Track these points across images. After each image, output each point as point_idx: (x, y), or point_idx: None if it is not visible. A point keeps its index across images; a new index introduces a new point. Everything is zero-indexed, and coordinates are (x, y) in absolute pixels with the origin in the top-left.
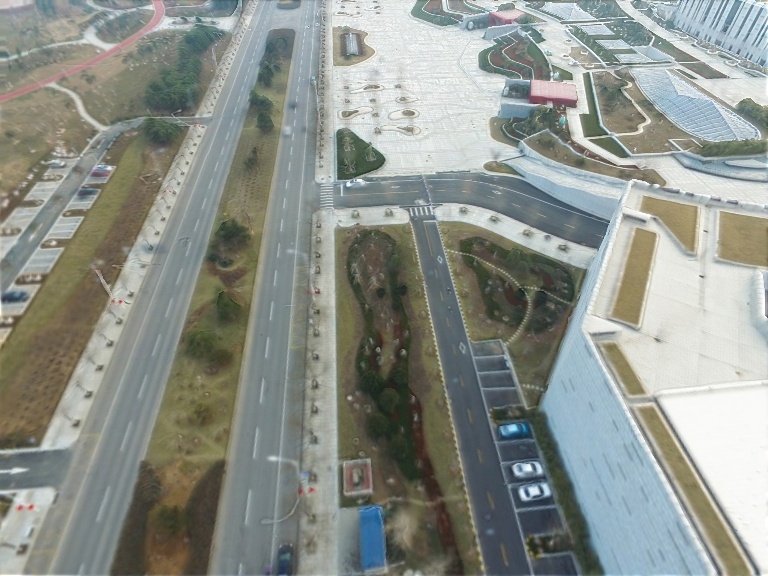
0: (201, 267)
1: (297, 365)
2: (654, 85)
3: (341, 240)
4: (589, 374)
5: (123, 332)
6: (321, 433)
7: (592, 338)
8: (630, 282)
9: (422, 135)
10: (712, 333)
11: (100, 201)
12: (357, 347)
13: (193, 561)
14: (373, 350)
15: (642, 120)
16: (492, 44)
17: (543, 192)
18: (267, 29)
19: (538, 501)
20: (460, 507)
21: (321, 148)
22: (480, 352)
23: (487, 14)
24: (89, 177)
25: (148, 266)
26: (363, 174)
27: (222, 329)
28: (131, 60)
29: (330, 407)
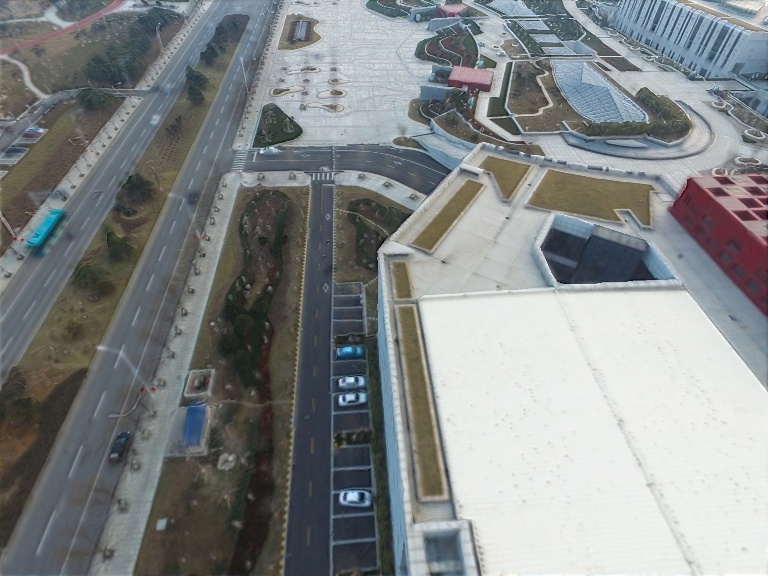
0: (107, 216)
1: (173, 297)
2: (567, 74)
3: (242, 198)
4: (380, 287)
5: (22, 266)
6: (179, 350)
7: (386, 258)
8: (441, 219)
9: (344, 112)
10: (493, 258)
11: (26, 158)
12: (231, 284)
13: (39, 441)
14: (243, 286)
15: (545, 104)
16: (434, 35)
17: (440, 164)
18: (223, 14)
19: (354, 406)
20: (284, 409)
21: (245, 120)
22: (340, 291)
23: (435, 7)
24: (20, 138)
25: (58, 214)
26: (278, 143)
27: (112, 266)
28: (84, 37)
29: (193, 330)
